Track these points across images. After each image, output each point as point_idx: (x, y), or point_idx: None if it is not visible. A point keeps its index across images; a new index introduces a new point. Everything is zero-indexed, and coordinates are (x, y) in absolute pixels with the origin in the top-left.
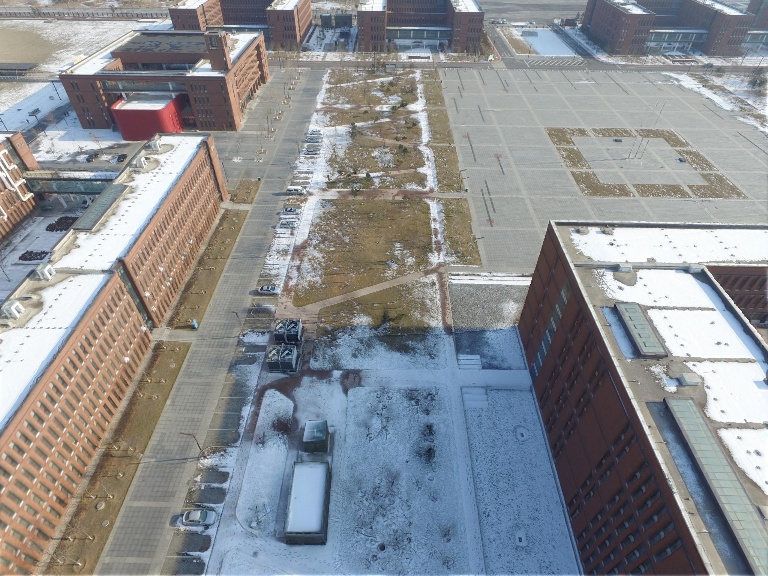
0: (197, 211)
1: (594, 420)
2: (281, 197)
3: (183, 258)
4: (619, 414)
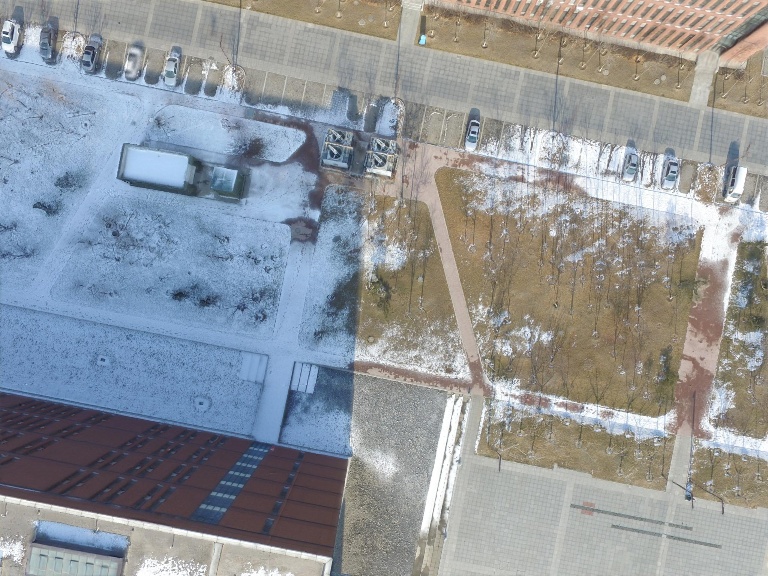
0: (649, 4)
1: (69, 460)
2: (723, 157)
3: (541, 1)
4: (3, 476)
